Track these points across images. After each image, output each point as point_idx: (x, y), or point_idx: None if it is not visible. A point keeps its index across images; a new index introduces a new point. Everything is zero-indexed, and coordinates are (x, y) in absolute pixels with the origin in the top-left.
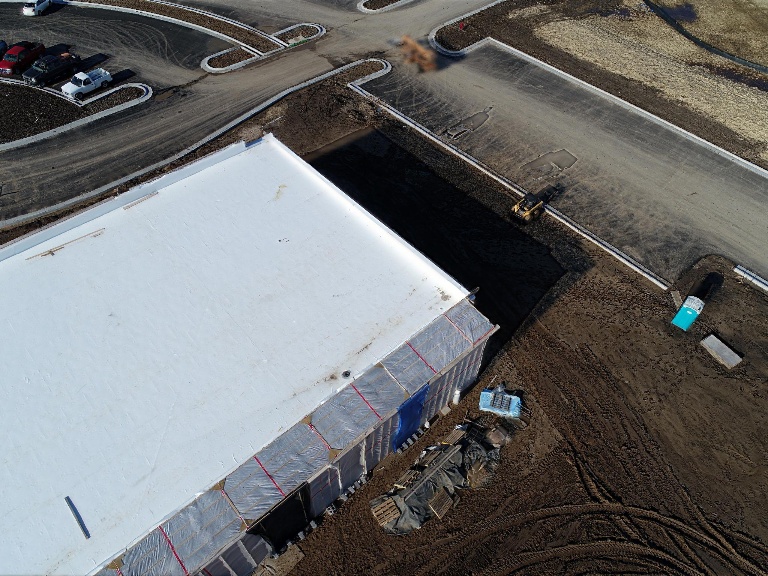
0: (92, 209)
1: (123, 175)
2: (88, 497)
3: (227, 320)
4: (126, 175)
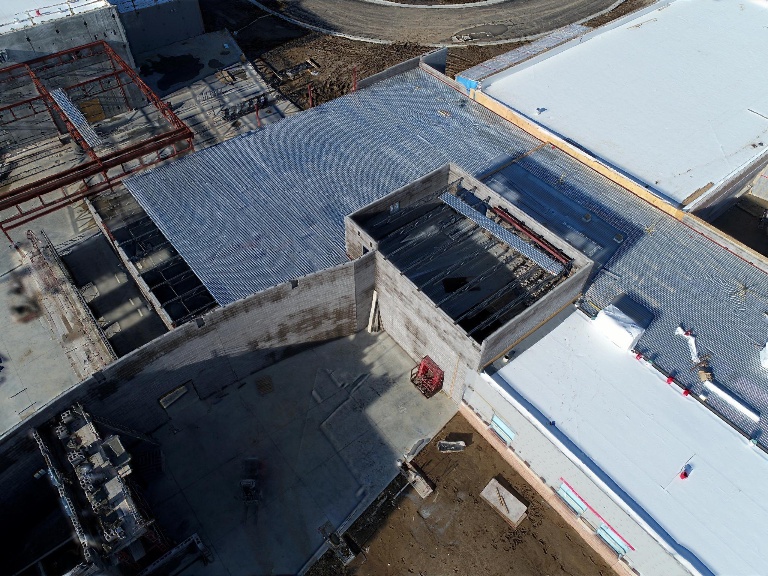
0: (650, 6)
1: (583, 17)
2: (759, 110)
3: (766, 56)
4: (585, 17)
